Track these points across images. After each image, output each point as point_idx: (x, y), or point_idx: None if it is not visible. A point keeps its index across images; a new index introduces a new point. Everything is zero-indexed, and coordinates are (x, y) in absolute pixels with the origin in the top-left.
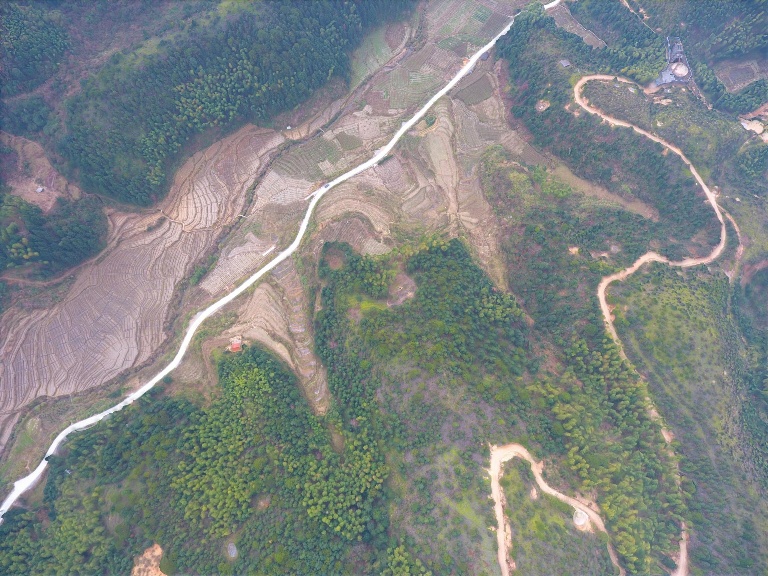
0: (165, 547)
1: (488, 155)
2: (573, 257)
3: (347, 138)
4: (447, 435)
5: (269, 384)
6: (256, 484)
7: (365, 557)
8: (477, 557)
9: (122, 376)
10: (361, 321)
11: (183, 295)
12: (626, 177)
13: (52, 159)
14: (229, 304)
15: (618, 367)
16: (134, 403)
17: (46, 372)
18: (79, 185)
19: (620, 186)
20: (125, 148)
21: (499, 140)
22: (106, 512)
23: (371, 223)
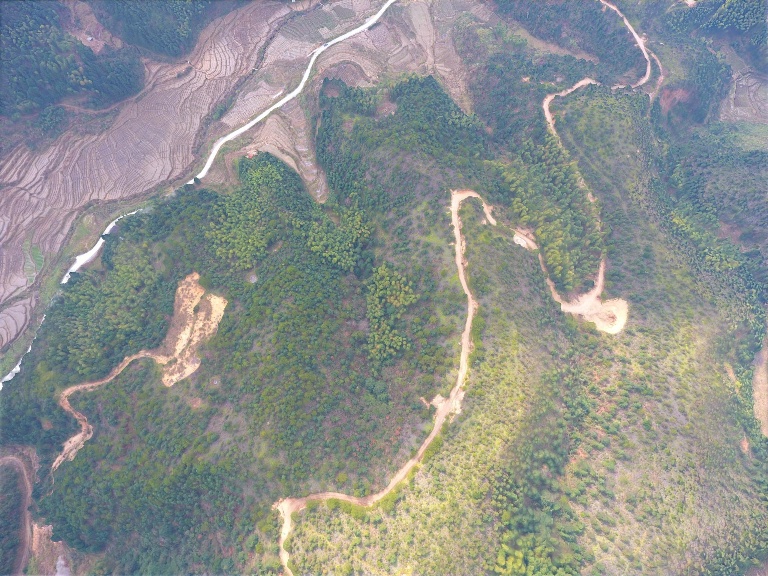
0: (202, 273)
1: (460, 20)
2: (525, 83)
3: (342, 10)
4: (420, 193)
5: (280, 175)
6: (271, 232)
7: (356, 282)
8: (440, 263)
9: (159, 186)
10: (353, 126)
11: (207, 128)
12: (573, 33)
13: (99, 14)
14: (246, 132)
15: (556, 153)
16: (172, 193)
17: (97, 181)
18: (121, 36)
19: (569, 41)
20: (159, 4)
21: (470, 11)
22: (154, 258)
23: (362, 69)
